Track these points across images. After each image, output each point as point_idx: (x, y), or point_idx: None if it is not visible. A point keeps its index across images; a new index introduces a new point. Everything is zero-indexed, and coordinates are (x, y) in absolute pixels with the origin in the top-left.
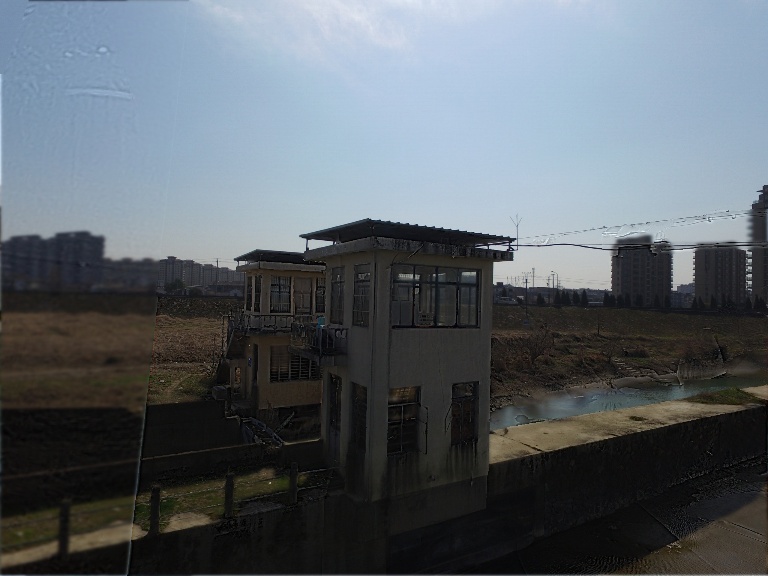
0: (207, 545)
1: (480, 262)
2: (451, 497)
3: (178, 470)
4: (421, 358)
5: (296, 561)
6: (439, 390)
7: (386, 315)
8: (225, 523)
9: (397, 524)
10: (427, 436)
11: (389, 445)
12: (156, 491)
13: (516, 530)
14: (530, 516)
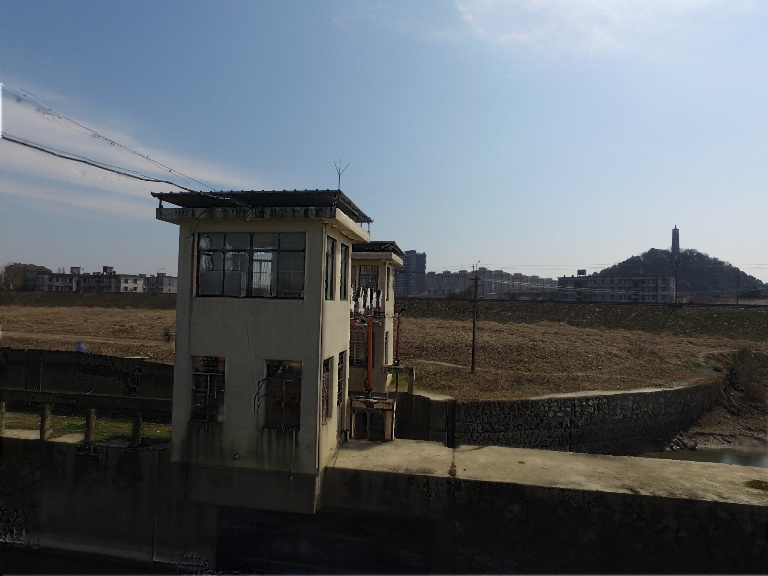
0: (71, 459)
1: (304, 224)
2: (263, 485)
3: (128, 409)
4: (226, 328)
5: (134, 497)
6: (247, 364)
7: (187, 283)
8: (83, 446)
9: (198, 492)
10: (232, 411)
11: (196, 412)
12: (43, 409)
13: (398, 566)
14: (424, 556)
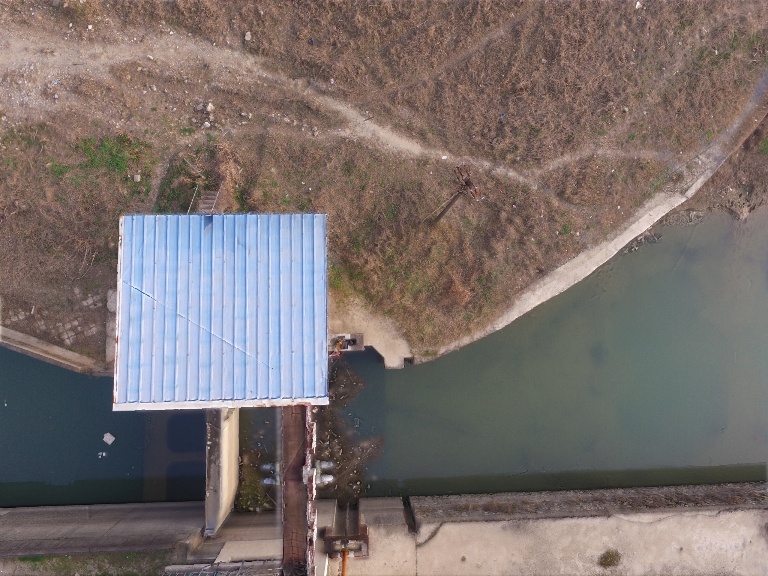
0: None
1: None
2: None
3: None
4: None
5: None
6: None
7: None
8: None
9: None
10: None
11: None
12: None
13: None
14: None
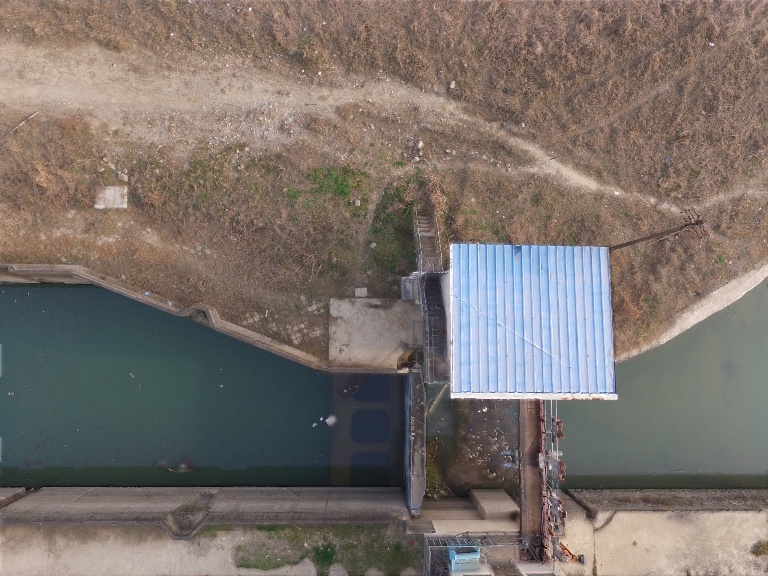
0: None
1: None
2: None
3: None
4: None
5: None
6: None
7: None
8: None
9: None
10: None
11: None
12: None
13: None
14: None
